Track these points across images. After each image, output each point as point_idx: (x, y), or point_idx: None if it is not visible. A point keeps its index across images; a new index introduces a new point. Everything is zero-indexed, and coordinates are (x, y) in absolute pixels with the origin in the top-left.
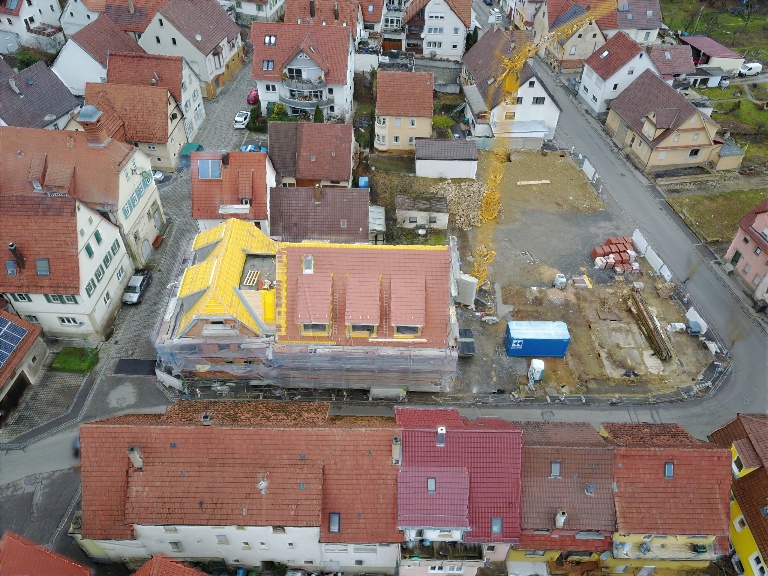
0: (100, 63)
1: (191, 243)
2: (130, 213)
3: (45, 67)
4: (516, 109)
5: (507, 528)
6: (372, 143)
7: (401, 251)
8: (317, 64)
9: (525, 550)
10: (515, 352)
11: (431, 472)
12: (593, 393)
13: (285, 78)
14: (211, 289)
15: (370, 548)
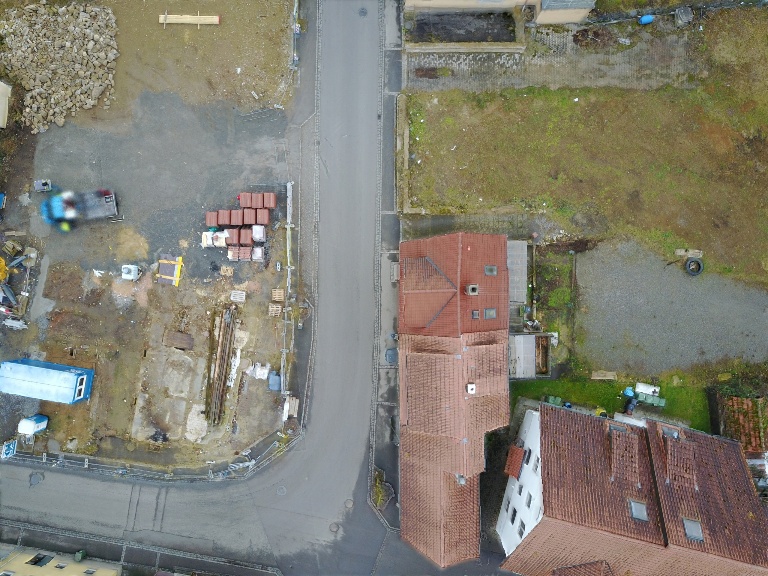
0: None
1: None
2: None
3: None
4: None
5: None
6: None
7: None
8: None
9: None
10: None
11: None
12: (102, 456)
13: None
14: None
15: None
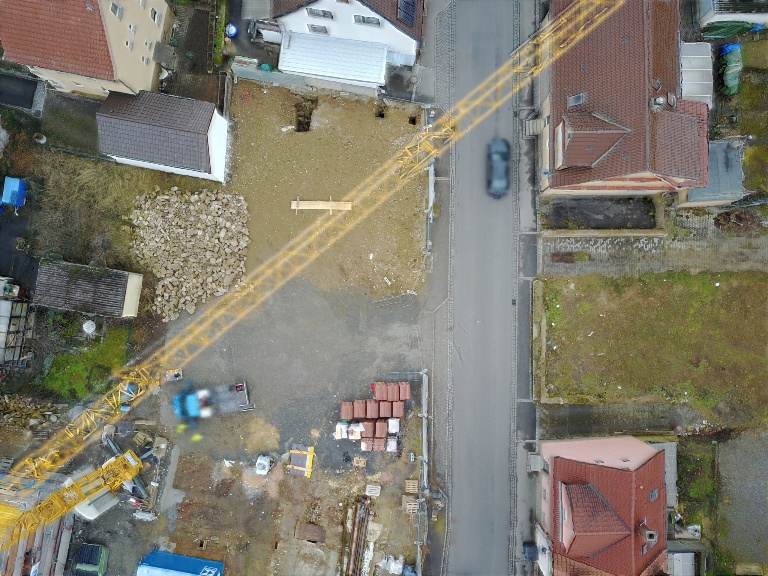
0: None
1: None
2: None
3: None
4: (325, 23)
5: None
6: None
7: None
8: None
9: None
10: None
11: None
12: None
13: None
14: None
15: None
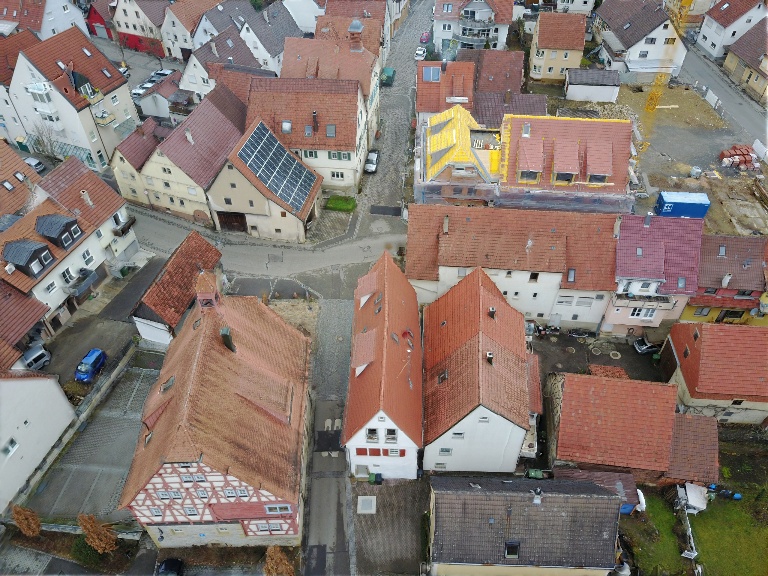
0: (317, 4)
1: (419, 127)
2: (371, 105)
3: (282, 5)
4: (649, 49)
5: (689, 285)
6: (526, 74)
7: (595, 123)
8: (489, 7)
9: (696, 307)
10: (665, 215)
11: (639, 244)
12: None
13: (462, 18)
14: (458, 144)
15: (588, 301)
